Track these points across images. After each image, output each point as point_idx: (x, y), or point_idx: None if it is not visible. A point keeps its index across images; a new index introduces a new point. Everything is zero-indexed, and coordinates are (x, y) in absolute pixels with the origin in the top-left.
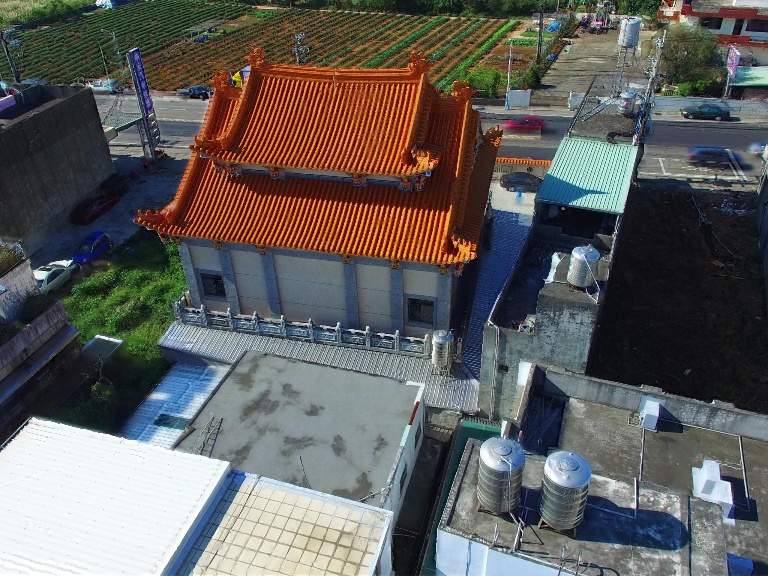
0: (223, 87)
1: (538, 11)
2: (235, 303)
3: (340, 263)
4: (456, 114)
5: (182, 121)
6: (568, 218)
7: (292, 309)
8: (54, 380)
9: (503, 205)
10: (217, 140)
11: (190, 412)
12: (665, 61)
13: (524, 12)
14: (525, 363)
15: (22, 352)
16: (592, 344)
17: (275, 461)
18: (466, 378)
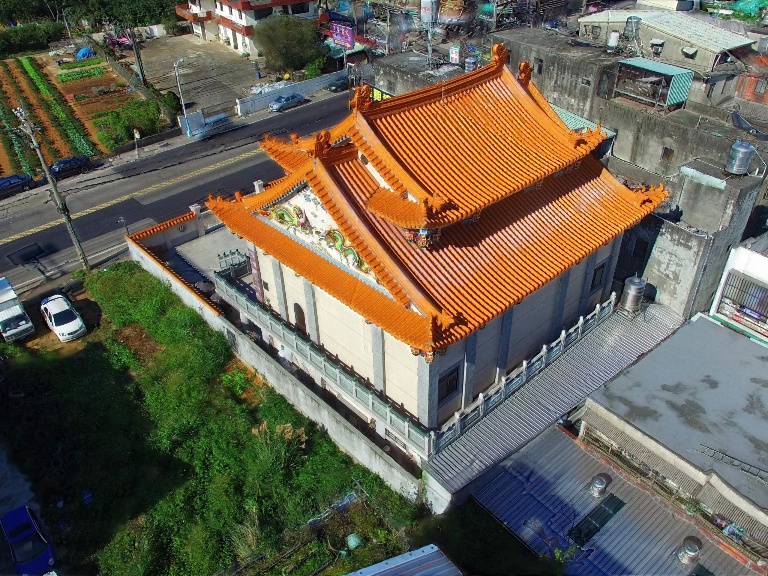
0: (326, 153)
1: (40, 42)
2: (470, 388)
3: None
4: None
5: None
6: None
7: (512, 353)
8: None
9: None
10: None
11: (582, 505)
12: (392, 36)
13: (22, 47)
14: None
15: None
16: None
17: None
18: (646, 308)
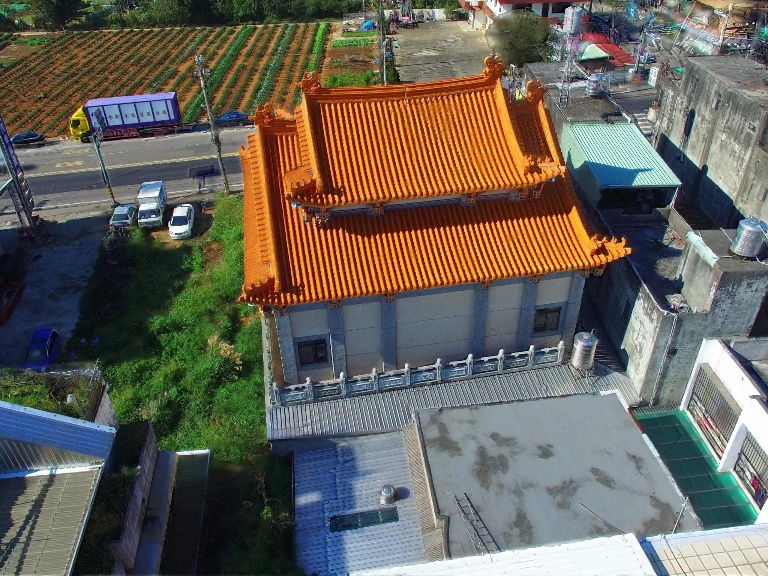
0: (267, 122)
1: (342, 12)
2: (341, 365)
3: (470, 291)
4: (530, 115)
5: (30, 177)
6: (604, 200)
7: (407, 354)
8: (171, 525)
9: None
10: (307, 184)
11: (364, 503)
12: None
13: (328, 14)
14: (711, 341)
15: (141, 504)
16: (762, 307)
17: (562, 518)
18: (607, 373)
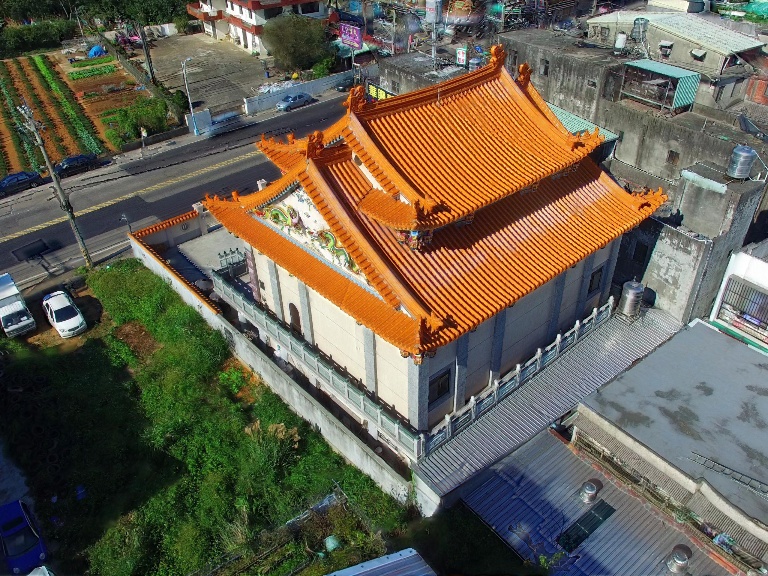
0: (319, 153)
1: (53, 40)
2: (462, 391)
3: None
4: None
5: None
6: None
7: (506, 356)
8: None
9: None
10: None
11: (572, 511)
12: (398, 37)
13: (36, 45)
14: (738, 254)
15: None
16: None
17: None
18: (645, 312)
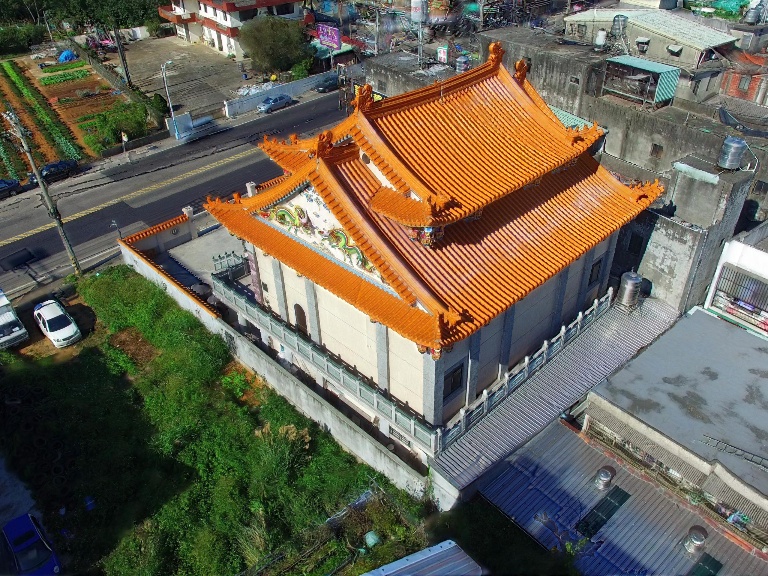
0: (328, 153)
1: (21, 45)
2: (474, 385)
3: None
4: None
5: None
6: None
7: (514, 349)
8: None
9: None
10: None
11: (588, 498)
12: (381, 37)
13: (3, 50)
14: None
15: None
16: None
17: None
18: (642, 302)
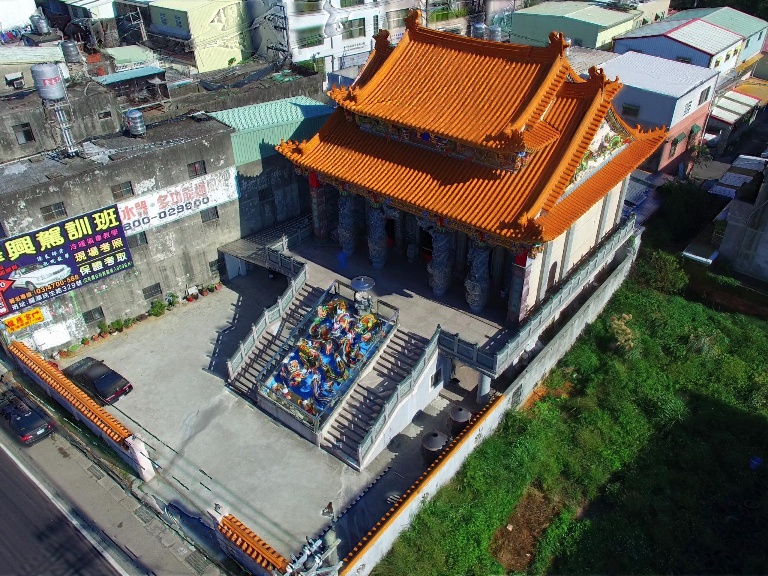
0: None
1: None
2: None
3: None
4: None
5: None
6: None
7: None
8: None
9: (175, 362)
10: None
11: None
12: None
13: None
14: None
15: None
16: None
17: None
18: None
